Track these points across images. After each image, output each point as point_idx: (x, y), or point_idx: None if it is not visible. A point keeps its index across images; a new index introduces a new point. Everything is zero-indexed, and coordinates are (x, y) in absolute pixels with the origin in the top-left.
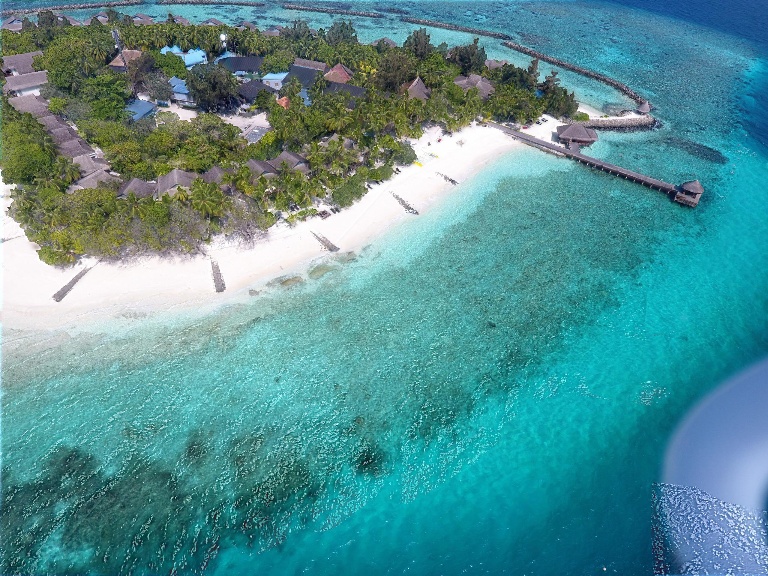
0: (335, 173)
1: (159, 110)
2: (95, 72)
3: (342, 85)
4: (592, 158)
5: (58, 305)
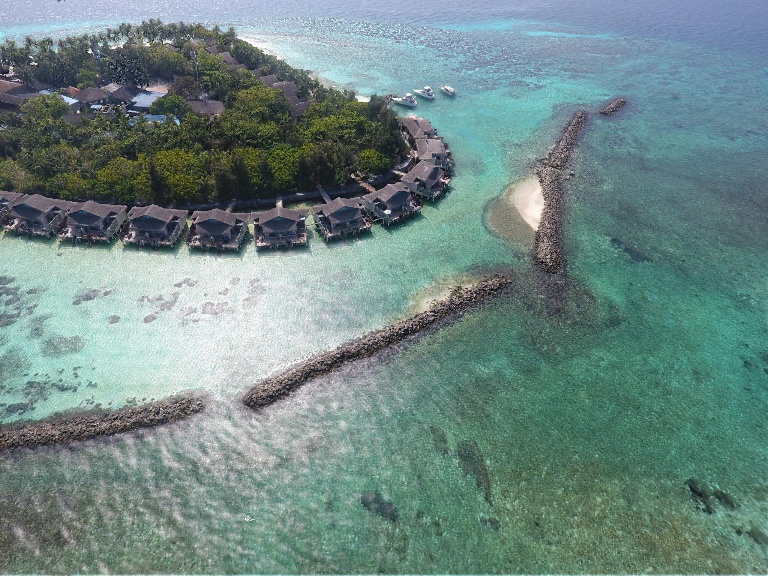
0: None
1: None
2: None
3: None
4: None
5: None
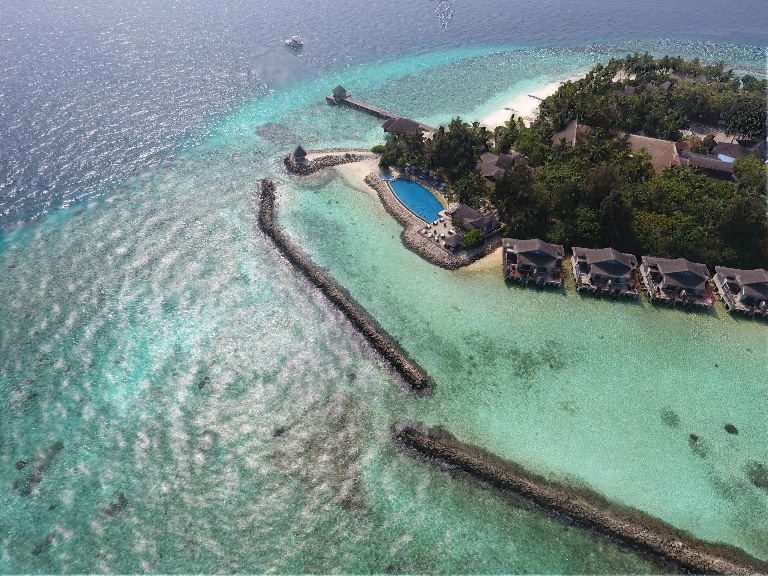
0: None
1: None
2: None
3: None
4: (395, 117)
5: None
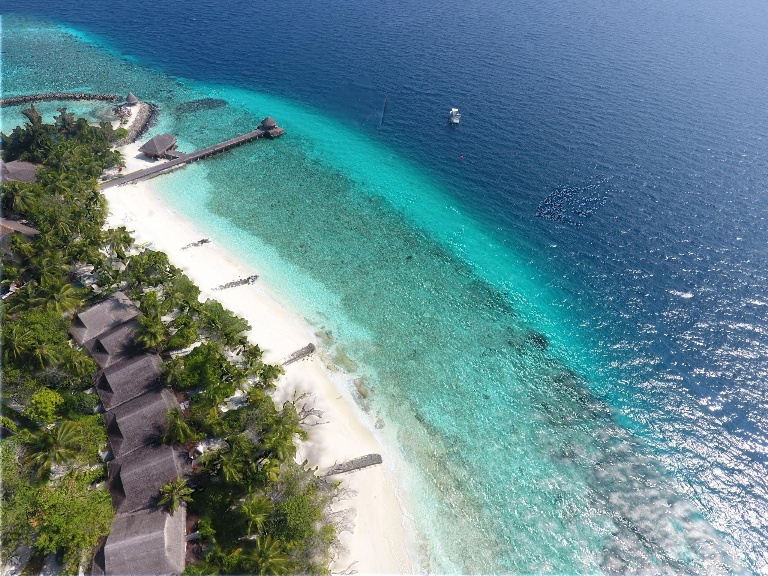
0: None
1: None
2: None
3: None
4: (200, 151)
5: None
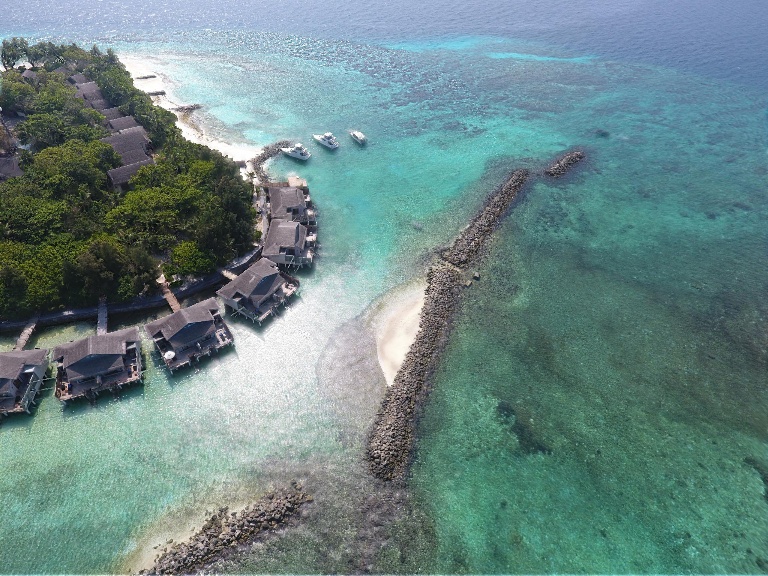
0: None
1: None
2: None
3: None
4: None
5: None
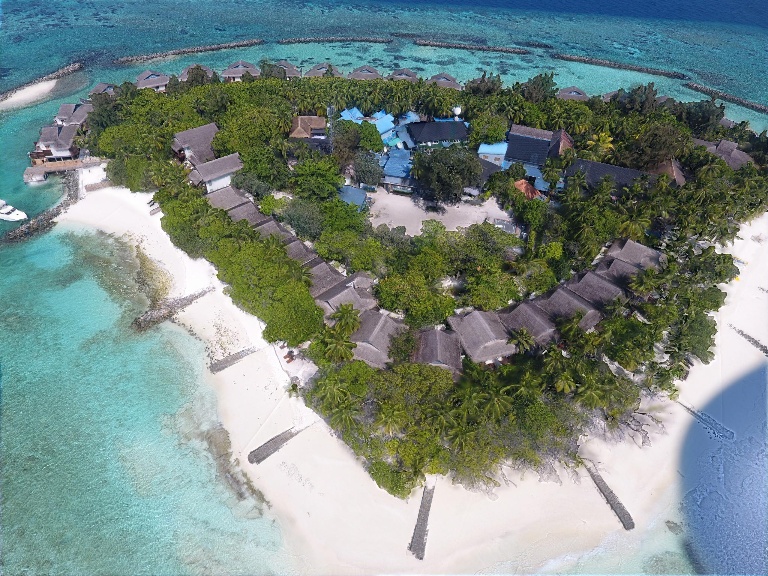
0: (690, 314)
1: (368, 197)
2: (295, 154)
3: (589, 163)
4: None
5: (424, 566)
